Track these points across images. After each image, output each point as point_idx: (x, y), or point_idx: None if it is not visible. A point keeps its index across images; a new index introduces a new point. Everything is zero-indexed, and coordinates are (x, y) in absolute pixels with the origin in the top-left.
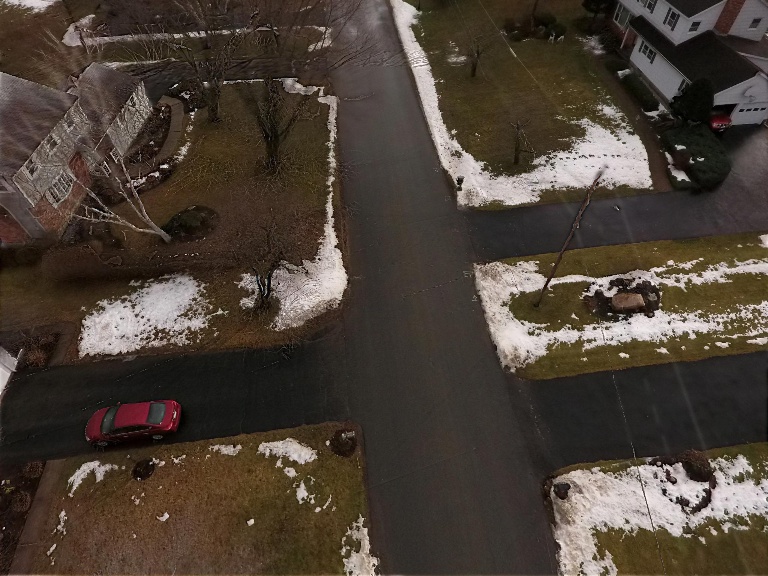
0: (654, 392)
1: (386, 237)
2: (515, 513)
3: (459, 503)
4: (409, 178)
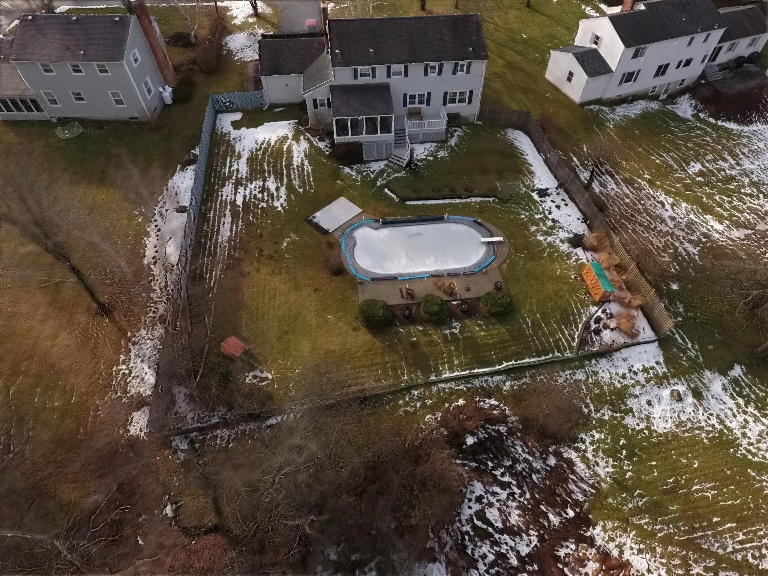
0: None
1: None
2: None
3: None
4: None
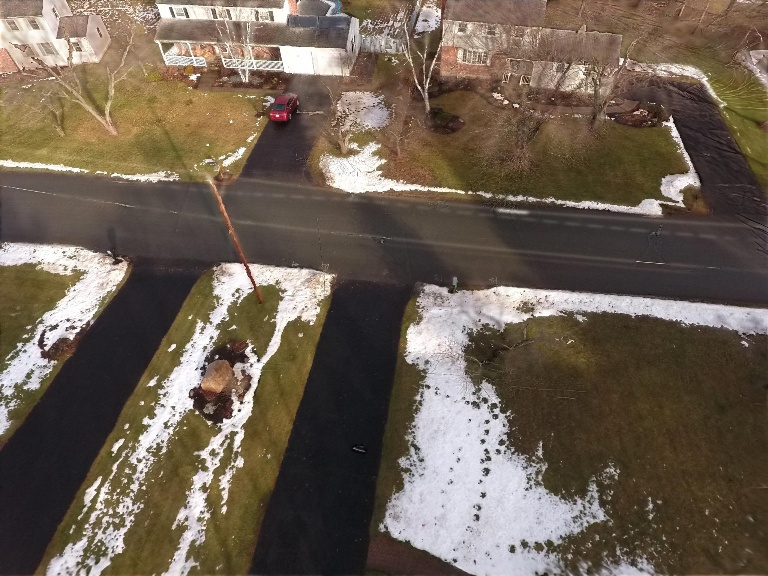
0: (128, 353)
1: (393, 220)
2: (127, 239)
3: (153, 215)
4: (481, 252)
